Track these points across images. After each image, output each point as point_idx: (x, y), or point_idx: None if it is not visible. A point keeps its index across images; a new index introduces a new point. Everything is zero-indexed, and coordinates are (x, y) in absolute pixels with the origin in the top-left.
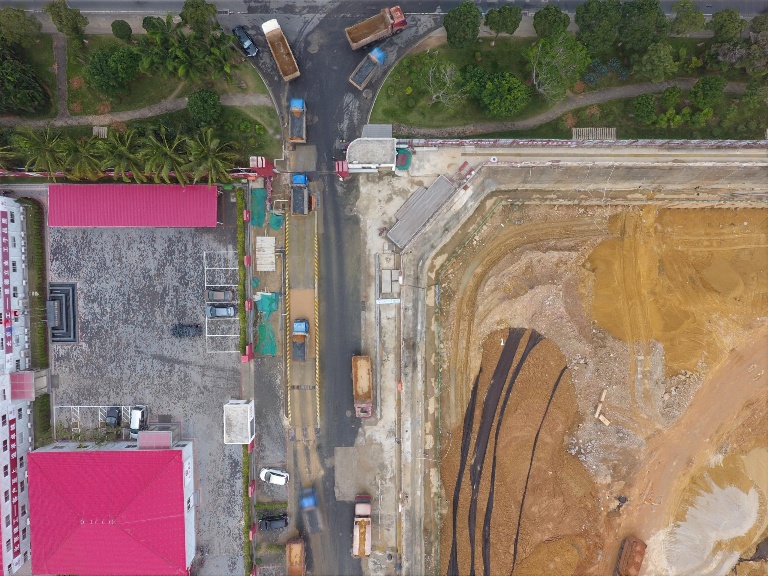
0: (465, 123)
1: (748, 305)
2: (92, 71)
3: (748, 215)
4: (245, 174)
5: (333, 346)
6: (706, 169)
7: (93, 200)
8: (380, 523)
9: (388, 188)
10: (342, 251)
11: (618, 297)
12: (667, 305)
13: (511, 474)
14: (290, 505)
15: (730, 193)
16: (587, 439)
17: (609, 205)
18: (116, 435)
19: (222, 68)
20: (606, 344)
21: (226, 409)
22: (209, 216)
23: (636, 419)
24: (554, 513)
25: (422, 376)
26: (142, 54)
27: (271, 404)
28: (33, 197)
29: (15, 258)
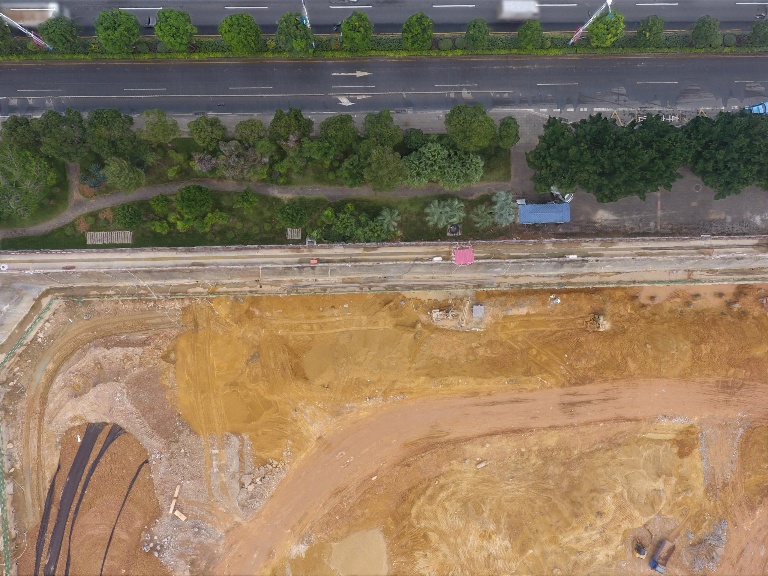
0: None
1: (338, 391)
2: None
3: (347, 298)
4: None
5: None
6: (228, 271)
7: None
8: None
9: None
10: None
11: (189, 391)
12: (251, 395)
13: (83, 574)
14: None
15: (293, 284)
16: (164, 535)
17: (175, 298)
18: None
19: None
20: (179, 439)
21: None
22: None
23: (214, 513)
24: None
25: None
26: None
27: None
28: None
29: None
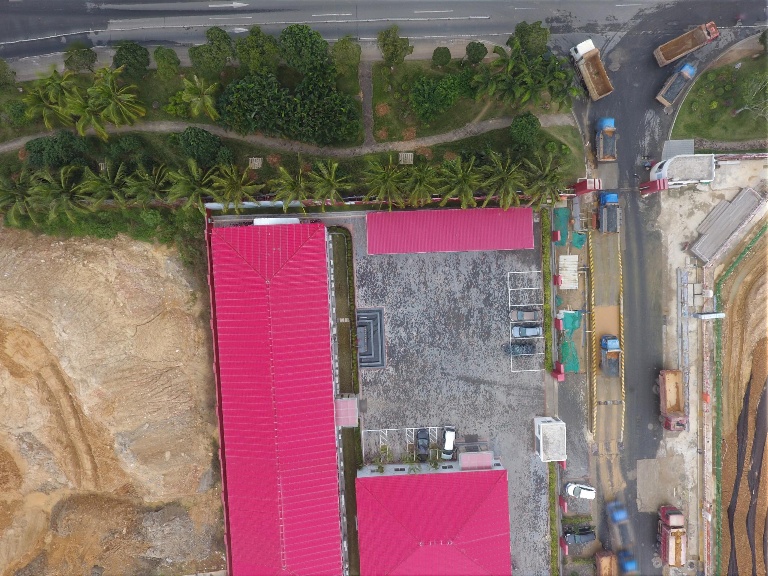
0: (767, 135)
1: None
2: (419, 99)
3: None
4: (560, 195)
5: (635, 361)
6: None
7: (411, 226)
8: None
9: (689, 203)
10: (644, 267)
11: None
12: None
13: None
14: (593, 518)
15: None
16: None
17: None
18: (427, 456)
19: (565, 92)
20: None
21: (543, 427)
22: (526, 238)
23: None
24: None
25: None
26: (482, 81)
27: (575, 420)
28: (340, 225)
29: (329, 286)
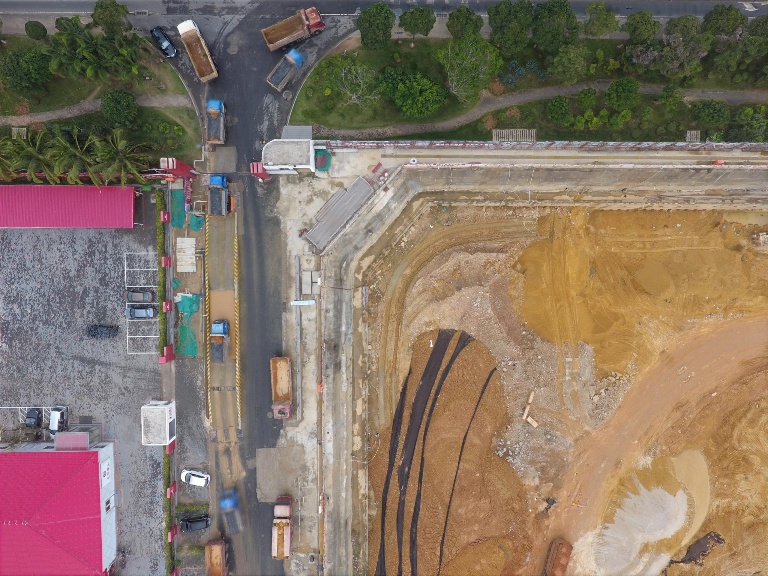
0: (385, 124)
1: (679, 307)
2: (5, 72)
3: (681, 217)
4: (162, 175)
5: (254, 347)
6: (627, 171)
7: (9, 201)
8: (302, 524)
9: (308, 189)
10: (263, 252)
11: (546, 299)
12: (597, 307)
13: (438, 476)
14: (212, 506)
15: (657, 195)
16: (515, 441)
17: (537, 207)
18: (36, 436)
19: (131, 69)
20: (534, 346)
21: (144, 410)
22: (126, 217)
23: (564, 421)
24: (480, 515)
25: (348, 377)
26: (51, 55)
27: (192, 405)
28: None
29: None
